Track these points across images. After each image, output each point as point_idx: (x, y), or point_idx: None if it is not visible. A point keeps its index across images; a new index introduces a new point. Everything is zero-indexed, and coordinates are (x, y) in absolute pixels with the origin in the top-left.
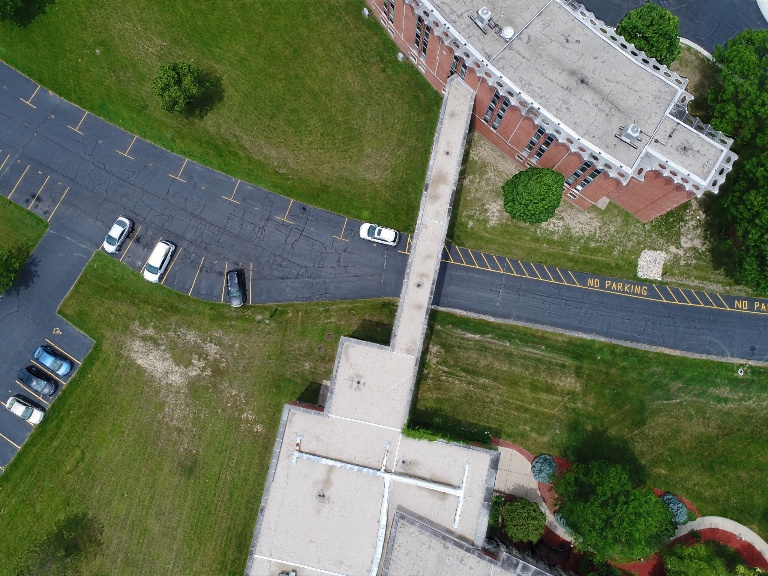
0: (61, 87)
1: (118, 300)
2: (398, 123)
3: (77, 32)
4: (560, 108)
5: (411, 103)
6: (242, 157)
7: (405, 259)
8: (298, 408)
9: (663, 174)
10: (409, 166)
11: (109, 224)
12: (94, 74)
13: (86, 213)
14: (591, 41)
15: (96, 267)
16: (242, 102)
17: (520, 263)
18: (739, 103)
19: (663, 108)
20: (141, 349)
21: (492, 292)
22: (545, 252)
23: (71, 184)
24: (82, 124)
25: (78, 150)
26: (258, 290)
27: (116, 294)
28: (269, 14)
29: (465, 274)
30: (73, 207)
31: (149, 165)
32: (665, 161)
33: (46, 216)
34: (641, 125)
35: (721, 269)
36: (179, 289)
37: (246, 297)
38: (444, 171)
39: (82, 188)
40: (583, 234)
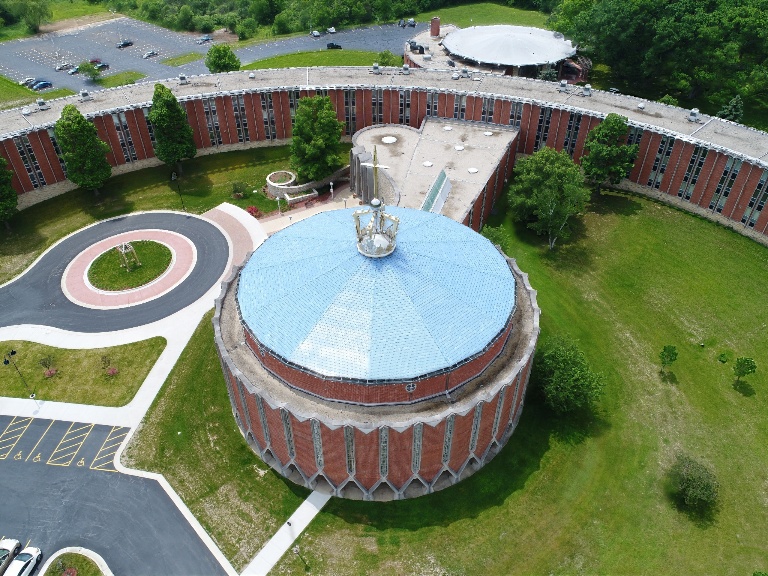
0: None
1: None
2: None
3: None
4: None
5: None
6: None
7: None
8: None
9: None
10: None
11: None
12: None
13: None
14: None
15: None
16: None
17: None
18: None
19: None
20: (24, 101)
21: None
22: None
23: None
24: None
25: None
26: None
27: None
28: None
29: None
30: None
31: None
32: None
33: None
34: None
35: None
36: None
37: None
38: None
39: None
40: None
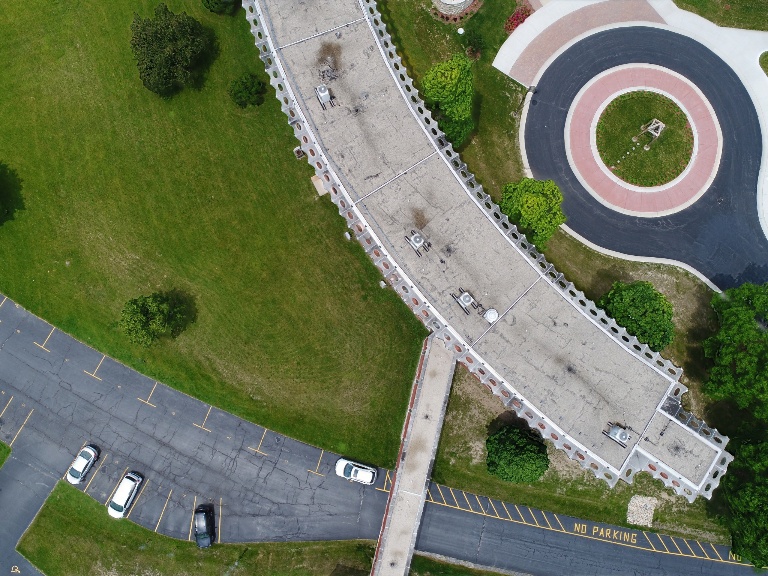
0: (28, 299)
1: (80, 536)
2: (379, 355)
3: (46, 241)
4: (545, 400)
5: (393, 334)
6: (215, 381)
7: (383, 497)
8: None
9: (653, 476)
10: (389, 400)
11: (74, 451)
12: (63, 287)
13: (50, 438)
14: (580, 325)
15: (59, 498)
16: (216, 324)
17: (503, 505)
18: (737, 377)
19: (655, 402)
20: None
21: (473, 536)
22: (530, 493)
23: (35, 406)
24: (49, 340)
25: (44, 369)
26: (227, 528)
27: (79, 529)
28: (246, 233)
29: (445, 515)
30: (37, 431)
31: (117, 387)
32: (655, 462)
33: (8, 440)
34: (631, 421)
35: (715, 517)
36: (145, 524)
37: (215, 535)
38: (423, 437)
39: (47, 411)
40: (570, 477)
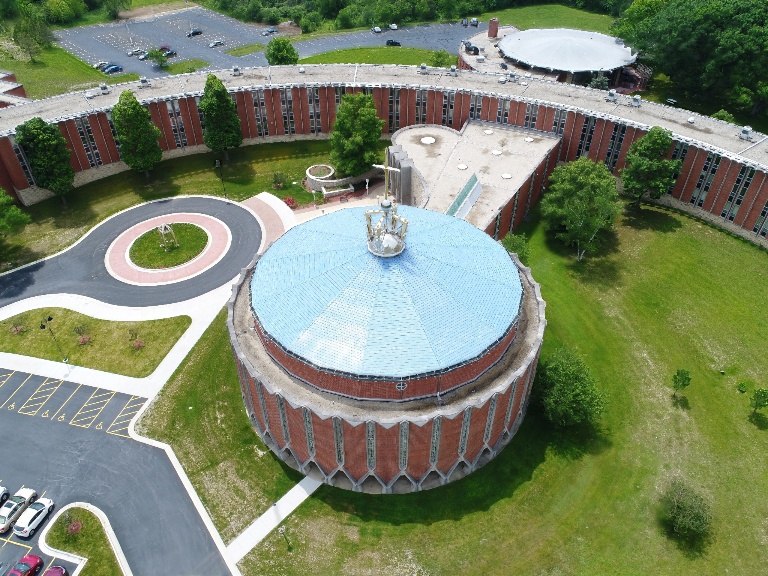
0: None
1: None
2: None
3: None
4: None
5: None
6: None
7: None
8: (8, 75)
9: None
10: None
11: None
12: None
13: None
14: None
15: None
16: None
17: None
18: None
19: None
20: None
21: None
22: None
23: None
24: None
25: None
26: None
27: None
28: None
29: None
30: None
31: None
32: None
33: None
34: None
35: None
36: None
37: None
38: None
39: None
40: None
